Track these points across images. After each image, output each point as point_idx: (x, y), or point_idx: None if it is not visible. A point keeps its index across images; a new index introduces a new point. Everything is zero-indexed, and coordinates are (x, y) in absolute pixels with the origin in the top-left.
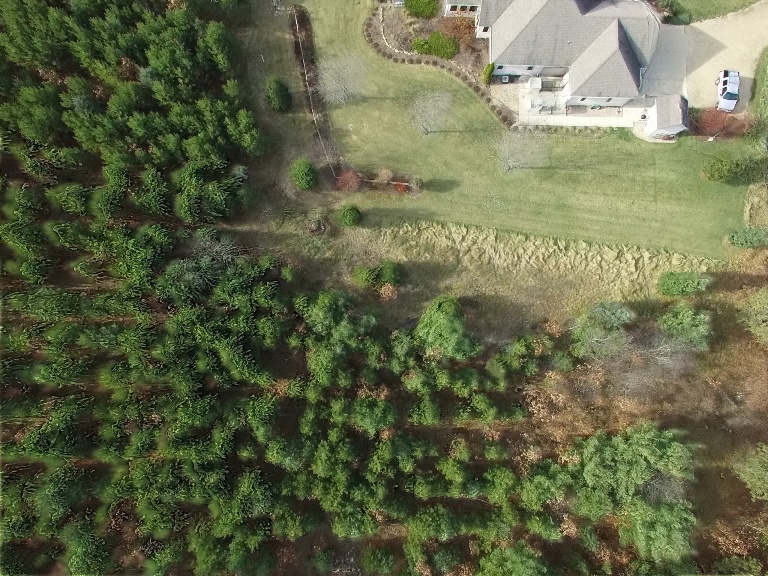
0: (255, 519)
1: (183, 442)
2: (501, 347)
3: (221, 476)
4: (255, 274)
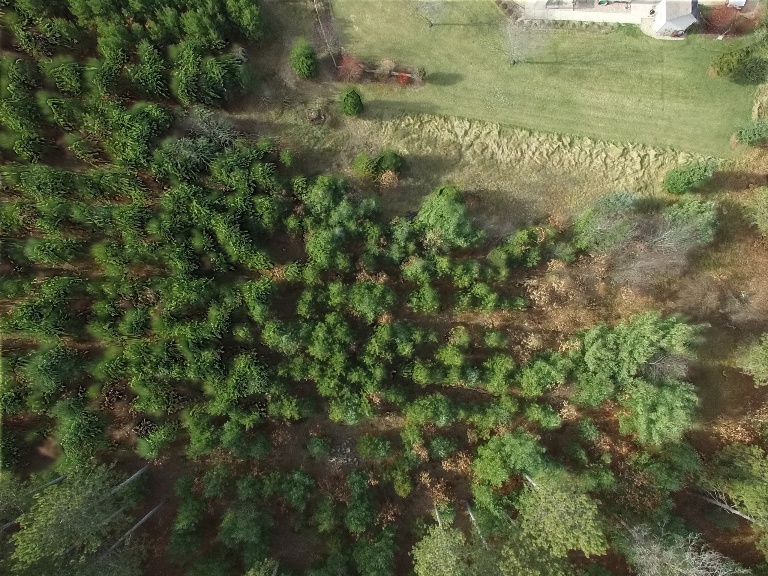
0: (251, 399)
1: (178, 322)
2: (503, 237)
3: (217, 356)
4: (253, 157)
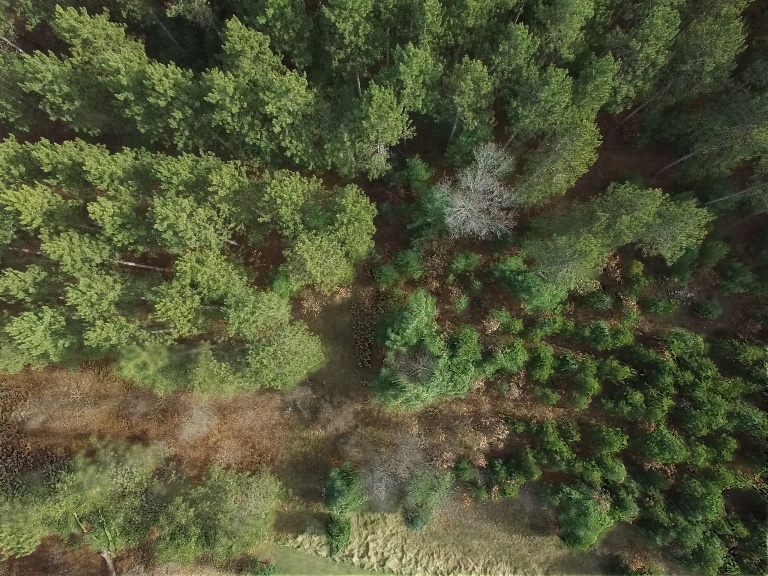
0: None
1: None
2: None
3: None
4: None
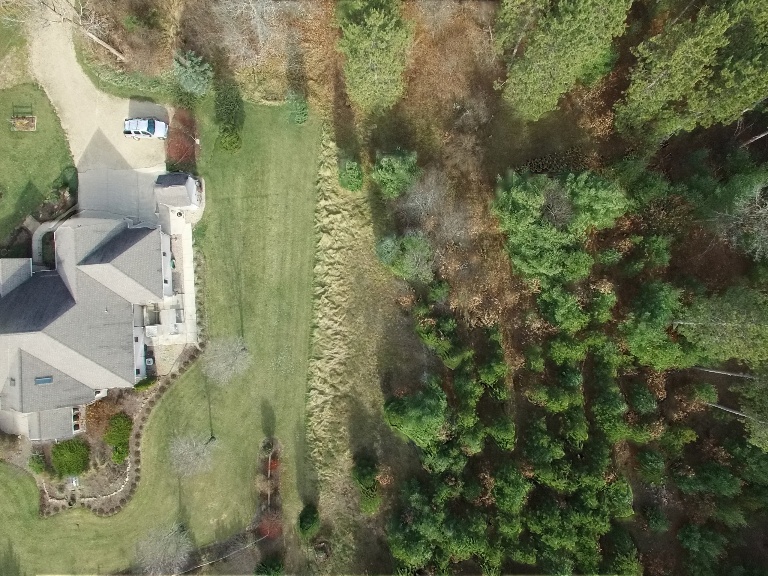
0: None
1: None
2: None
3: None
4: None
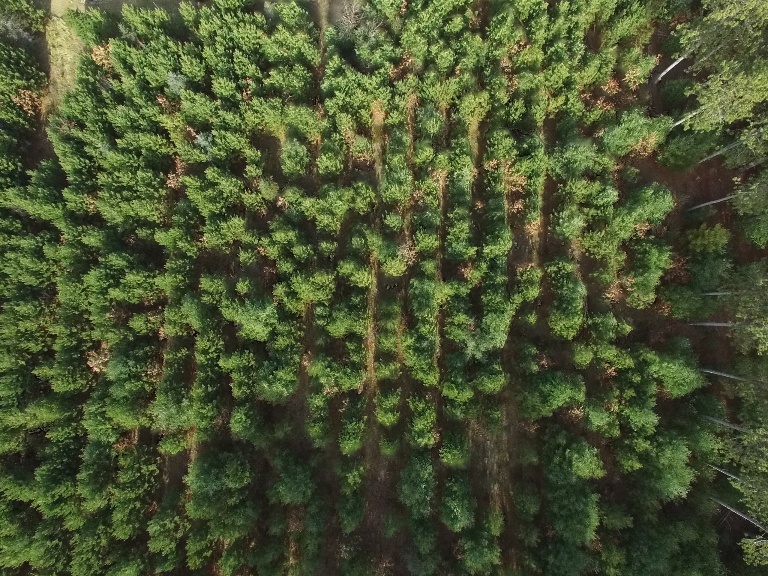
0: None
1: (532, 46)
2: None
3: (566, 6)
4: None
